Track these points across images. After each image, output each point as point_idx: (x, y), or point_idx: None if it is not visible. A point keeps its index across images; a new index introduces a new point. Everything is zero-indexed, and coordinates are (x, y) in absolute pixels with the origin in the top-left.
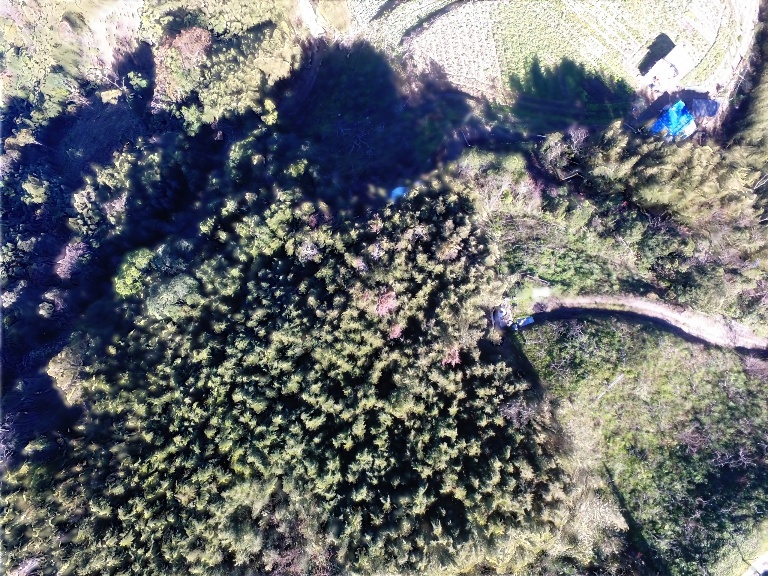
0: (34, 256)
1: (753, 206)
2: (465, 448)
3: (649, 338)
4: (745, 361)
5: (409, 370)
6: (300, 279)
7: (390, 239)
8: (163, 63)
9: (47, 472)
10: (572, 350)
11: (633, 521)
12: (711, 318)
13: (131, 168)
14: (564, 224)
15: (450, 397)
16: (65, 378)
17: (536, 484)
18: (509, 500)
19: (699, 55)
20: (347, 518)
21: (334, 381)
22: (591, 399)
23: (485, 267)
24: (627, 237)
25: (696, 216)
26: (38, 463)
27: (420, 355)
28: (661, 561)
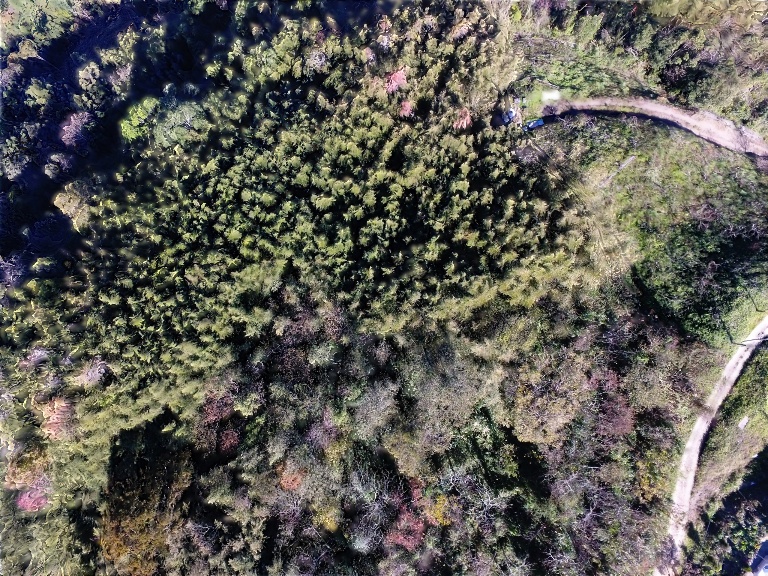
0: None
1: None
2: (477, 199)
3: (660, 130)
4: (756, 163)
5: (420, 139)
6: (308, 91)
7: (399, 34)
8: None
9: (55, 285)
10: (583, 139)
11: (645, 288)
12: (721, 122)
13: (136, 44)
14: (573, 40)
15: None
16: (72, 203)
17: (549, 219)
18: (522, 231)
19: None
20: (358, 279)
21: (344, 170)
22: (602, 179)
23: (496, 43)
24: (637, 41)
25: None
26: None
27: (431, 124)
28: (674, 319)
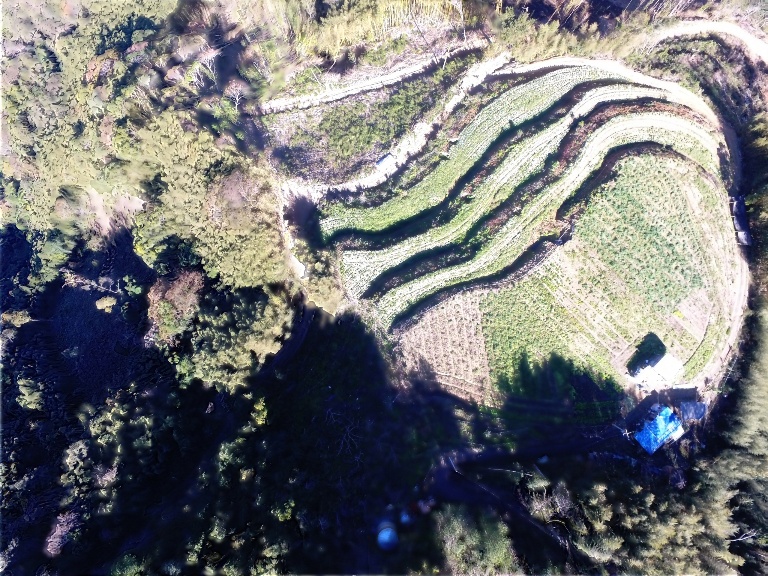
0: (27, 492)
1: None
2: None
3: None
4: None
5: None
6: None
7: None
8: None
9: None
10: None
11: None
12: None
13: (123, 425)
14: None
15: None
16: None
17: None
18: None
19: (687, 353)
20: None
21: None
22: None
23: None
24: None
25: None
26: None
27: None
28: None
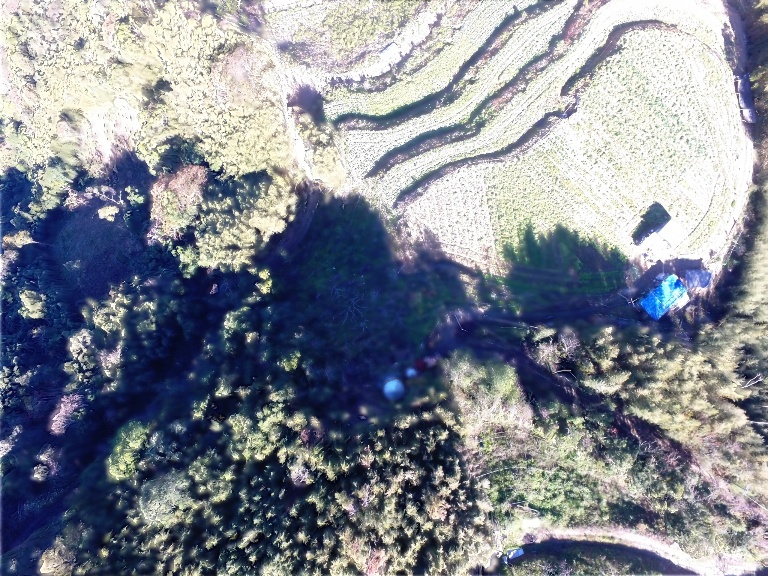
0: (30, 389)
1: (743, 419)
2: None
3: None
4: None
5: None
6: (291, 499)
7: (380, 478)
8: (159, 200)
9: None
10: None
11: None
12: None
13: (127, 313)
14: (555, 440)
15: None
16: None
17: None
18: None
19: (692, 224)
20: None
21: None
22: None
23: (474, 530)
24: (617, 466)
25: (686, 442)
26: None
27: None
28: None
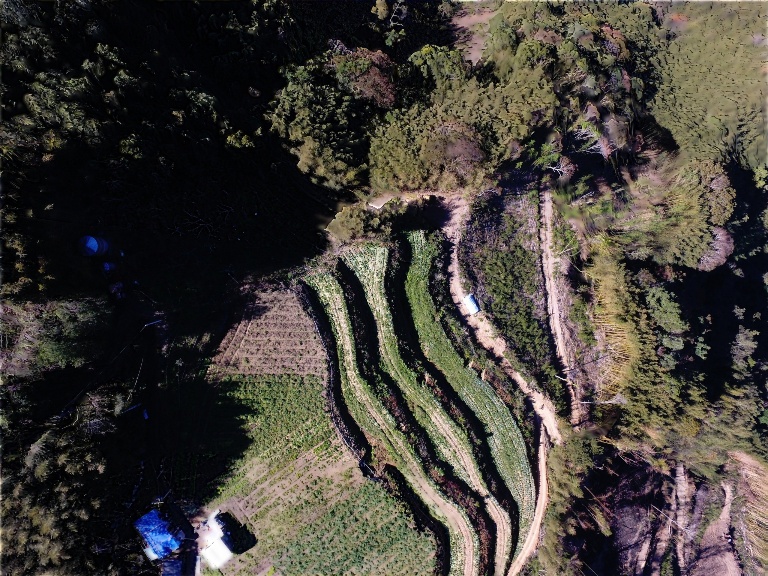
0: None
1: None
2: None
3: None
4: None
5: None
6: None
7: None
8: None
9: None
10: None
11: None
12: None
13: (253, 4)
14: None
15: None
16: None
17: None
18: None
19: (230, 575)
20: None
21: None
22: None
23: None
24: None
25: None
26: None
27: None
28: None
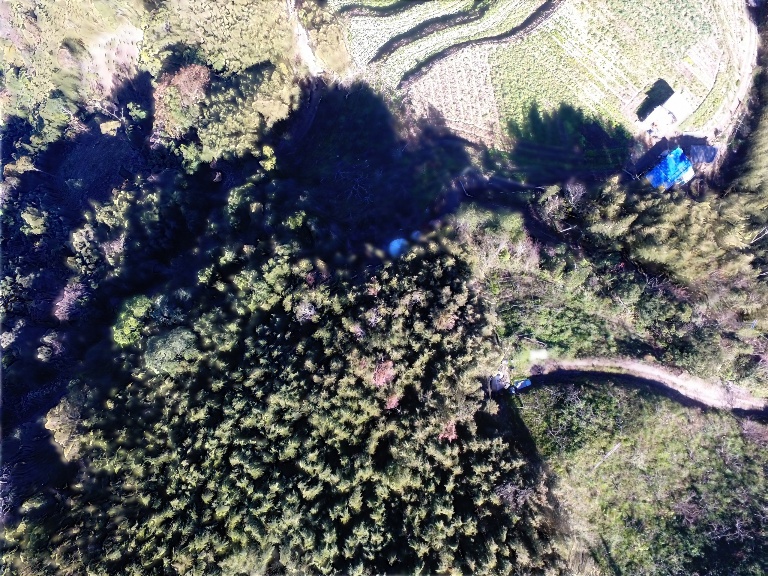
0: (33, 292)
1: (750, 263)
2: (461, 527)
3: (646, 404)
4: (742, 424)
5: (406, 443)
6: (298, 338)
7: (387, 304)
8: (162, 100)
9: (44, 531)
10: (569, 417)
11: None
12: (708, 380)
13: (130, 207)
14: (562, 282)
15: (447, 471)
16: (63, 433)
17: (532, 568)
18: None
19: (697, 101)
20: None
21: (331, 448)
22: (588, 468)
23: (482, 338)
24: (624, 299)
25: (693, 277)
26: (35, 521)
27: (417, 428)
28: None
